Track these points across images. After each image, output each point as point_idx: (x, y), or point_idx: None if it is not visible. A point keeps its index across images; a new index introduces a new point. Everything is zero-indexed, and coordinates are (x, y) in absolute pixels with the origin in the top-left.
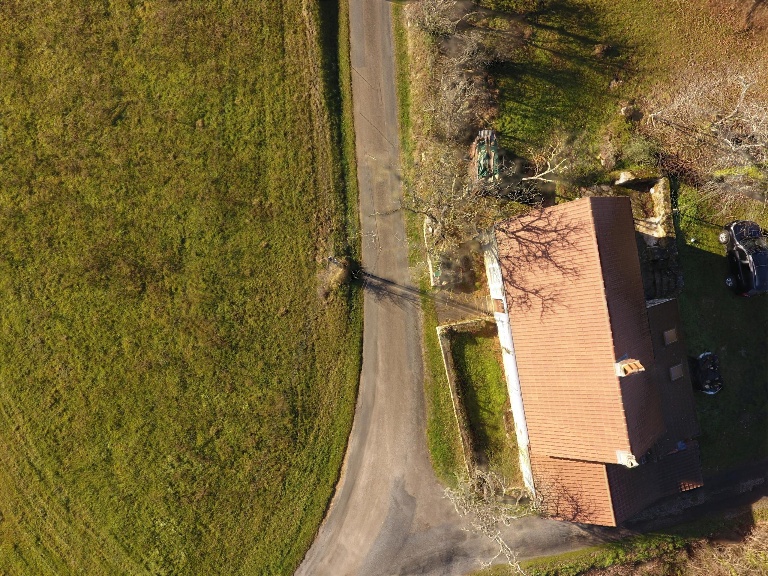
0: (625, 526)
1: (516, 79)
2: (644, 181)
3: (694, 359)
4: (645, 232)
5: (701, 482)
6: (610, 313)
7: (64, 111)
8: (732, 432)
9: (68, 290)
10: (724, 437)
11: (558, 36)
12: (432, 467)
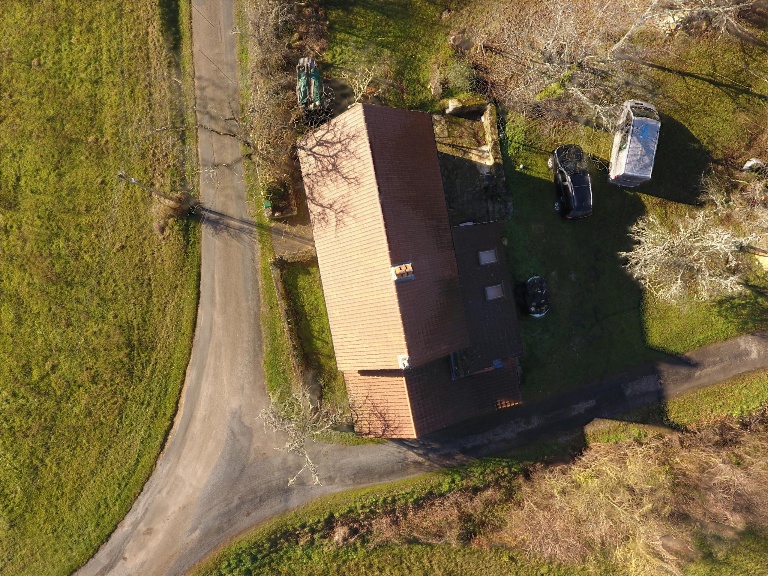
0: (460, 451)
1: (348, 11)
2: (475, 109)
3: (523, 283)
4: (478, 160)
5: (519, 400)
6: (386, 218)
7: None
8: (562, 355)
9: None
10: (554, 360)
11: None
12: None
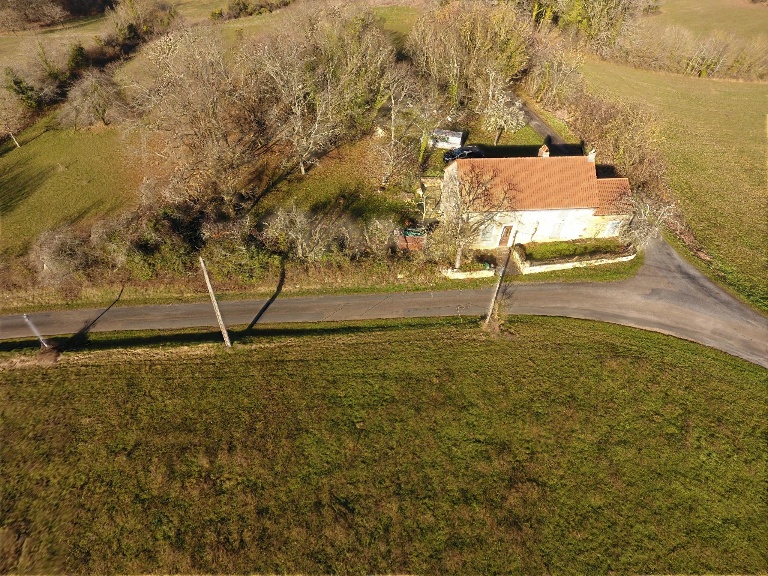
0: None
1: (353, 231)
2: None
3: None
4: None
5: None
6: None
7: (330, 575)
8: None
9: (552, 570)
10: None
11: (328, 215)
12: (625, 280)
